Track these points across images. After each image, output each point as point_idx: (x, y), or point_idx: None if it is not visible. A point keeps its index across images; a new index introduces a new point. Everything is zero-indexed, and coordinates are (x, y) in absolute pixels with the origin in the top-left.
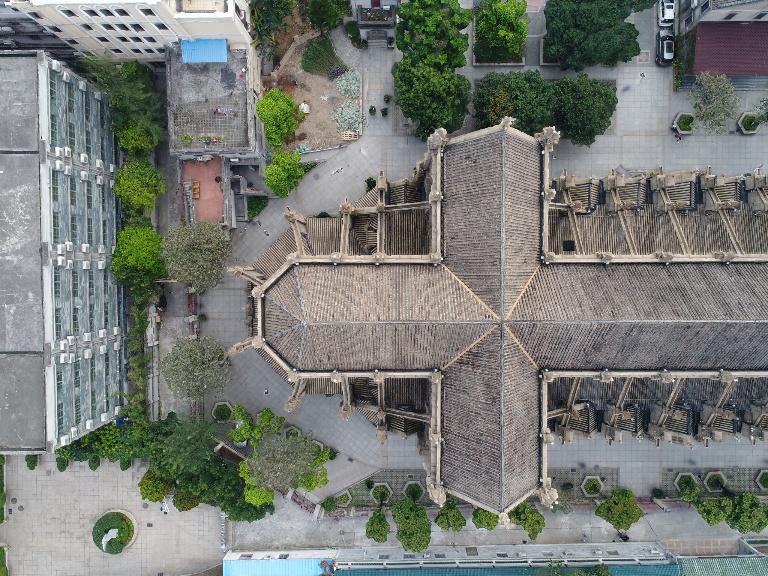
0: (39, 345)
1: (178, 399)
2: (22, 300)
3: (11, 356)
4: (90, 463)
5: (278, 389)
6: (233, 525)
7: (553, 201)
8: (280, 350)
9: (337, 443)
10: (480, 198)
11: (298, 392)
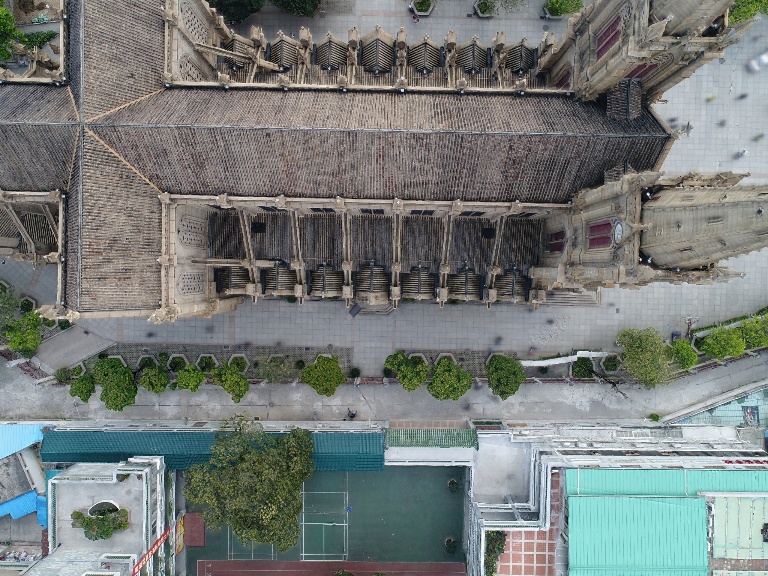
0: None
1: None
2: None
3: None
4: None
5: None
6: None
7: None
8: None
9: None
10: (77, 7)
11: None
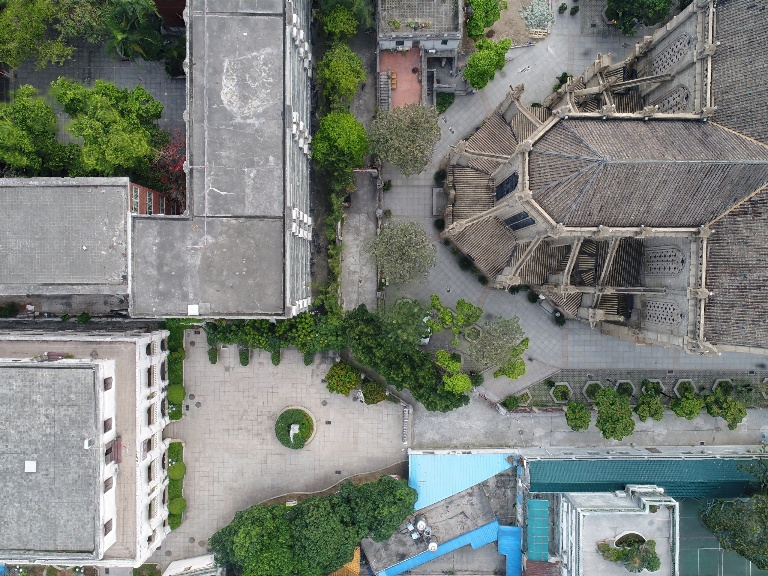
0: (279, 209)
1: (360, 296)
2: (263, 164)
3: (250, 220)
4: (274, 357)
5: (460, 287)
6: (412, 423)
7: None
8: (545, 205)
9: (518, 342)
10: None
11: (518, 270)
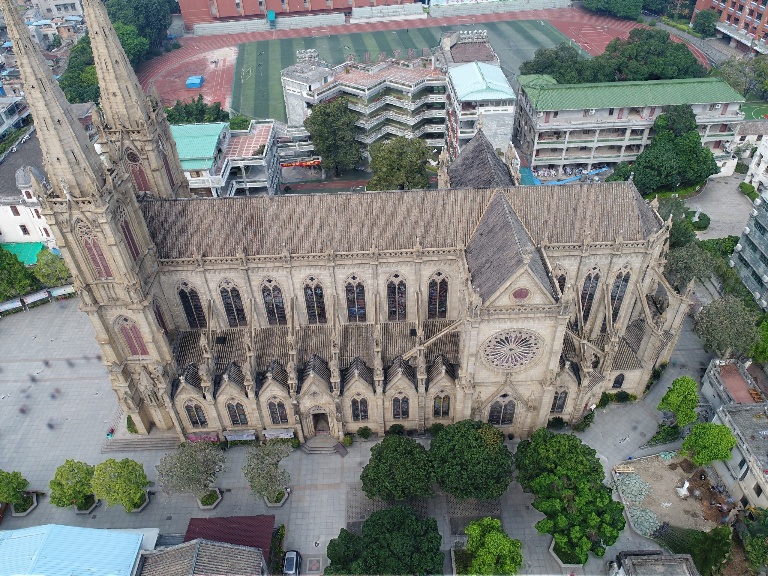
0: None
1: None
2: None
3: None
4: None
5: None
6: None
7: (427, 373)
8: None
9: None
10: None
11: None
